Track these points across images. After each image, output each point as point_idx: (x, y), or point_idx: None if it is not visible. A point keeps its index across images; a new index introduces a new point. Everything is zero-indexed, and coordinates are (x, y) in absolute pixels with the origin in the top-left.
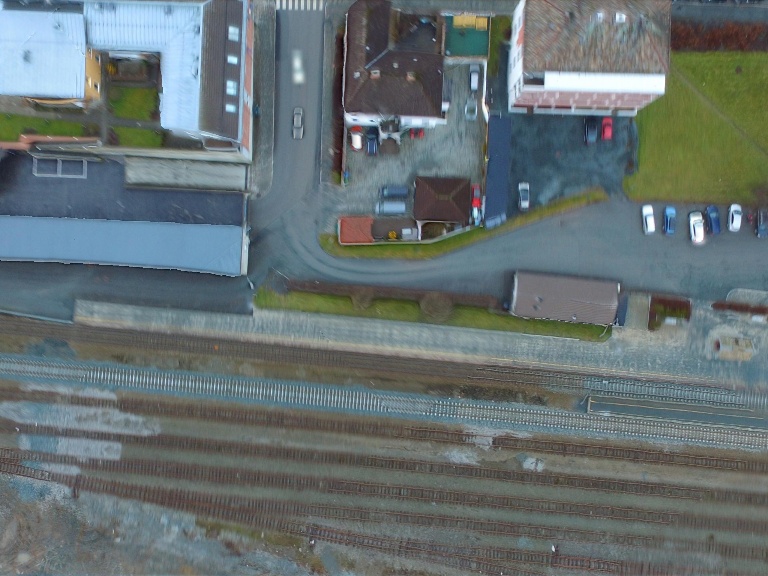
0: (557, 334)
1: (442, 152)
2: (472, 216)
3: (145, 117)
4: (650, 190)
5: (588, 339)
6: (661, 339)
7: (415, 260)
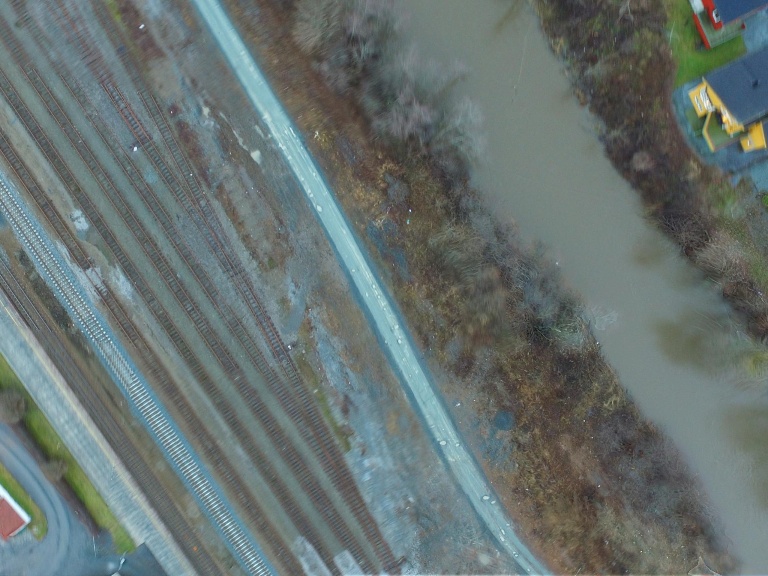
0: None
1: None
2: None
3: None
4: None
5: None
6: None
7: None
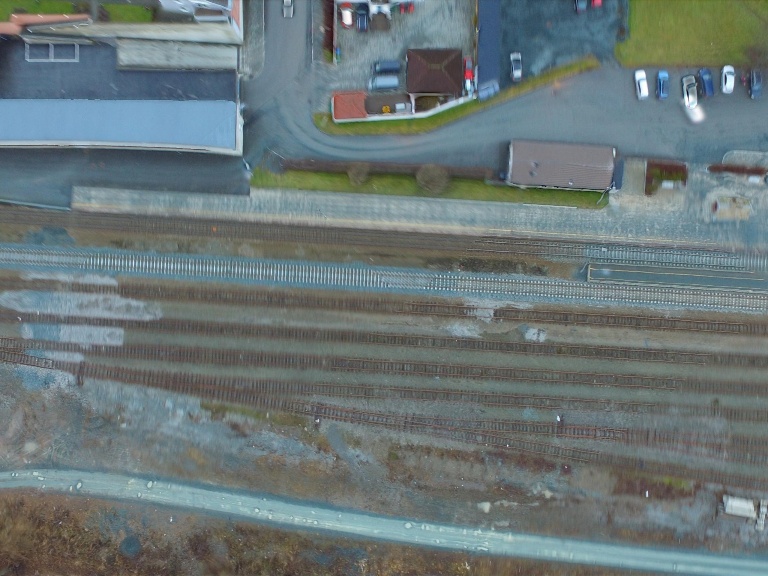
0: (554, 203)
1: (433, 27)
2: (465, 88)
3: None
4: (642, 56)
5: (585, 207)
6: (658, 204)
7: (410, 135)
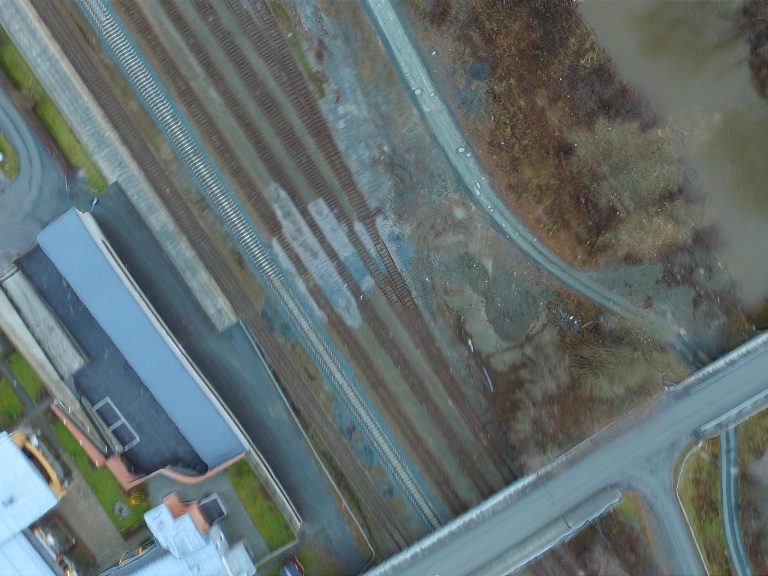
0: None
1: None
2: None
3: (5, 383)
4: None
5: None
6: None
7: None
